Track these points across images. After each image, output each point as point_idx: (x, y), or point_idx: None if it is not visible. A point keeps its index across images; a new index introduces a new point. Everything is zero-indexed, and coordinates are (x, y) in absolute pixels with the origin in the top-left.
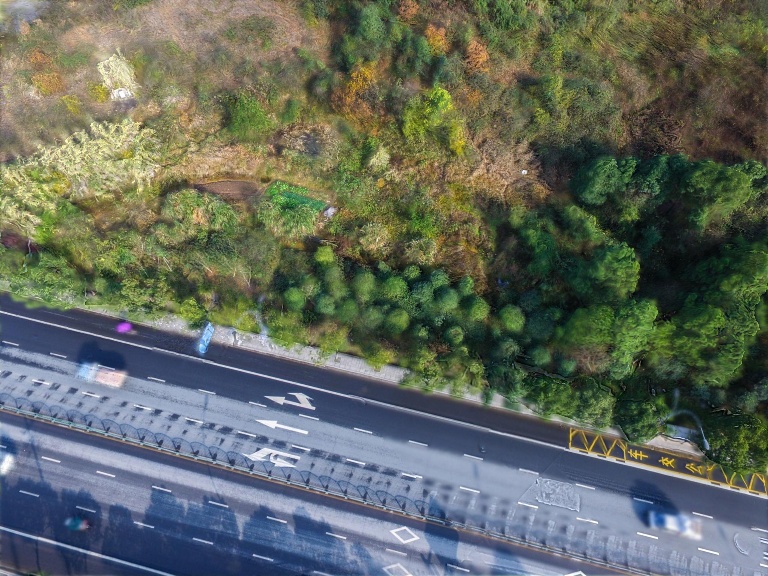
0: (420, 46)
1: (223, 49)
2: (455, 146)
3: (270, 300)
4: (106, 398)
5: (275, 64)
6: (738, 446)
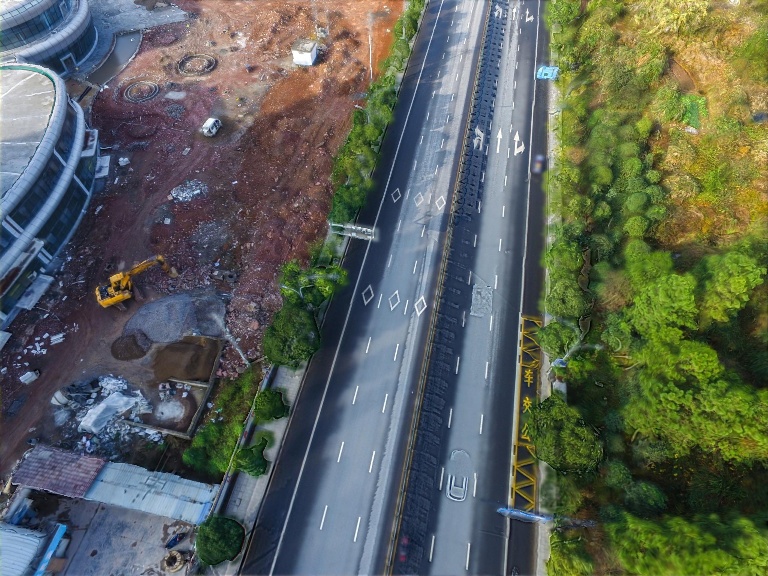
0: None
1: None
2: None
3: None
4: (499, 69)
5: None
6: (557, 407)
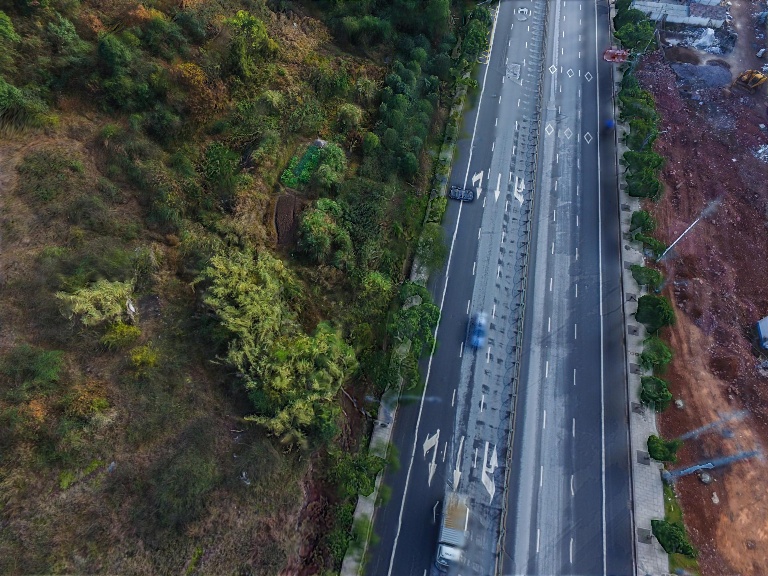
0: (161, 24)
1: (73, 204)
2: (272, 45)
3: (402, 191)
4: (495, 300)
5: (107, 167)
6: None
